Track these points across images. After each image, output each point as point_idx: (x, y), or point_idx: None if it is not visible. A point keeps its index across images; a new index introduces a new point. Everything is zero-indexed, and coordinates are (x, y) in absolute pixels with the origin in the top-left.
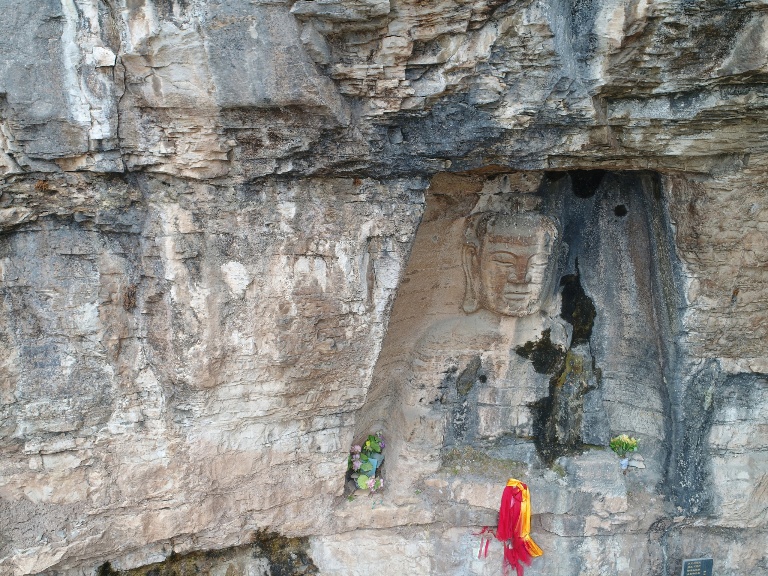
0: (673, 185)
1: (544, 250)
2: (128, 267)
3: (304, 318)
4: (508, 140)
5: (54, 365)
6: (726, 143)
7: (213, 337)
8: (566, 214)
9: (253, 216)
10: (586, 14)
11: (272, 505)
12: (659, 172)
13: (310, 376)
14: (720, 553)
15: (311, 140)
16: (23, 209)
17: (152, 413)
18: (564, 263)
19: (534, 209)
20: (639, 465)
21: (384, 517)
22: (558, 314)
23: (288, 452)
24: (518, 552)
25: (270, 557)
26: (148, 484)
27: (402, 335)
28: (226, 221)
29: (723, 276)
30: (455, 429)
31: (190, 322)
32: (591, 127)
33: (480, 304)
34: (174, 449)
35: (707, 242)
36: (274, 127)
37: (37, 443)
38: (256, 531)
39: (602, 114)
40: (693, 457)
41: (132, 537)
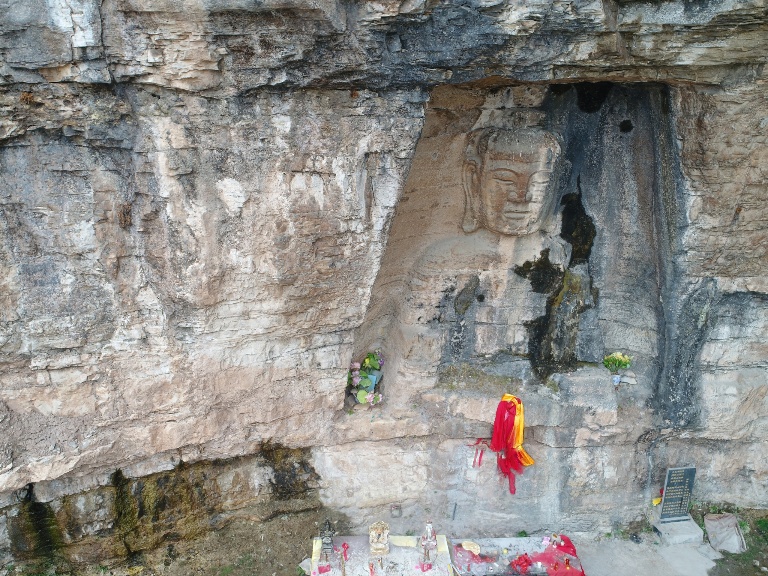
0: (682, 98)
1: (546, 167)
2: (122, 184)
3: (302, 236)
4: (512, 48)
5: (54, 283)
6: (740, 51)
7: (211, 255)
8: (570, 130)
9: (247, 130)
10: None
11: (275, 418)
12: (668, 84)
13: (309, 294)
14: (703, 463)
15: (305, 48)
16: (9, 123)
17: (154, 330)
18: (566, 181)
19: (537, 125)
20: (631, 381)
21: (383, 429)
22: (558, 234)
23: (289, 368)
24: (511, 461)
25: (274, 466)
26: (154, 398)
27: (401, 255)
28: (220, 136)
29: (727, 194)
30: (452, 347)
31: (187, 240)
32: (600, 33)
33: (479, 223)
34: (177, 365)
35: (713, 158)
36: (266, 33)
37: (43, 359)
38: (260, 442)
39: (612, 19)
40: (684, 373)
41: (141, 447)
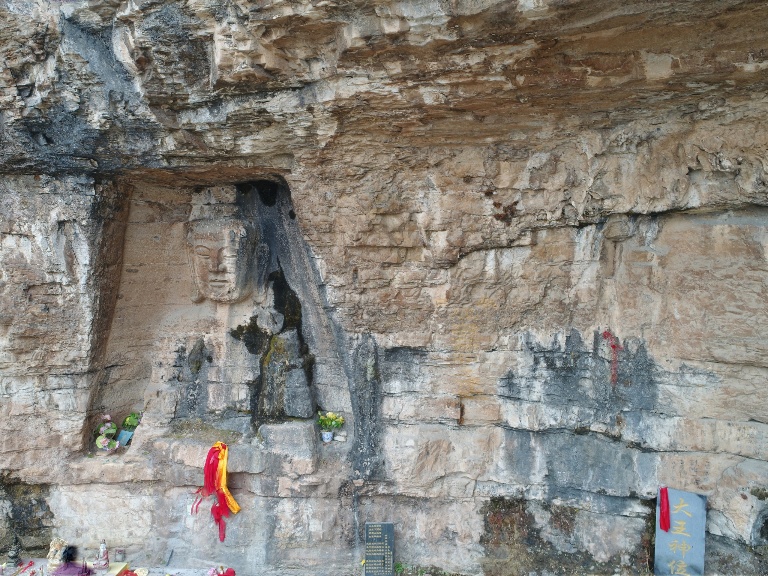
0: None
1: (231, 244)
2: None
3: (15, 284)
4: (116, 141)
5: None
6: (273, 142)
7: None
8: (262, 220)
9: None
10: (111, 48)
11: (9, 449)
12: None
13: (26, 333)
14: (410, 523)
15: None
16: None
17: None
18: (266, 261)
19: (232, 215)
20: (340, 439)
21: (112, 472)
22: (271, 305)
23: (27, 405)
24: (221, 508)
25: (13, 501)
26: None
27: (145, 321)
28: None
29: (335, 255)
30: (189, 403)
31: None
32: (169, 130)
33: None
34: None
35: (310, 225)
36: None
37: None
38: None
39: (169, 120)
40: (368, 425)
41: None
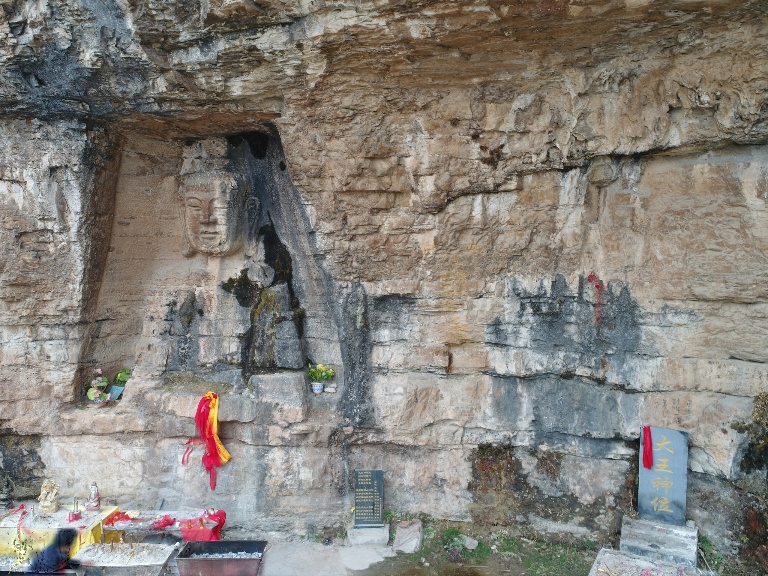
0: None
1: (222, 196)
2: None
3: (6, 230)
4: (107, 82)
5: None
6: (263, 82)
7: None
8: (253, 174)
9: None
10: None
11: (0, 399)
12: None
13: (18, 280)
14: (399, 471)
15: None
16: None
17: None
18: (257, 214)
19: (223, 168)
20: (330, 390)
21: (103, 422)
22: (262, 260)
23: (18, 355)
24: (212, 457)
25: (4, 451)
26: None
27: (136, 275)
28: None
29: (325, 200)
30: (180, 357)
31: None
32: (160, 71)
33: (193, 248)
34: None
35: (300, 170)
36: None
37: None
38: None
39: (160, 59)
40: (357, 374)
41: None
